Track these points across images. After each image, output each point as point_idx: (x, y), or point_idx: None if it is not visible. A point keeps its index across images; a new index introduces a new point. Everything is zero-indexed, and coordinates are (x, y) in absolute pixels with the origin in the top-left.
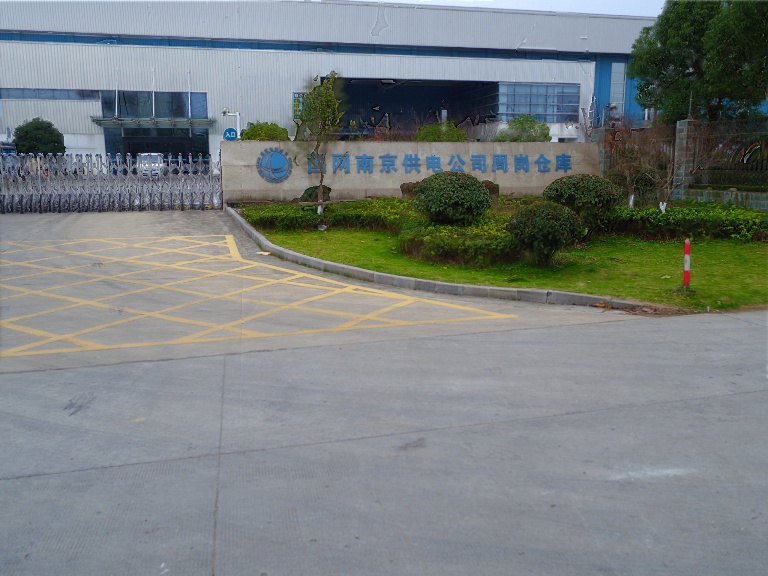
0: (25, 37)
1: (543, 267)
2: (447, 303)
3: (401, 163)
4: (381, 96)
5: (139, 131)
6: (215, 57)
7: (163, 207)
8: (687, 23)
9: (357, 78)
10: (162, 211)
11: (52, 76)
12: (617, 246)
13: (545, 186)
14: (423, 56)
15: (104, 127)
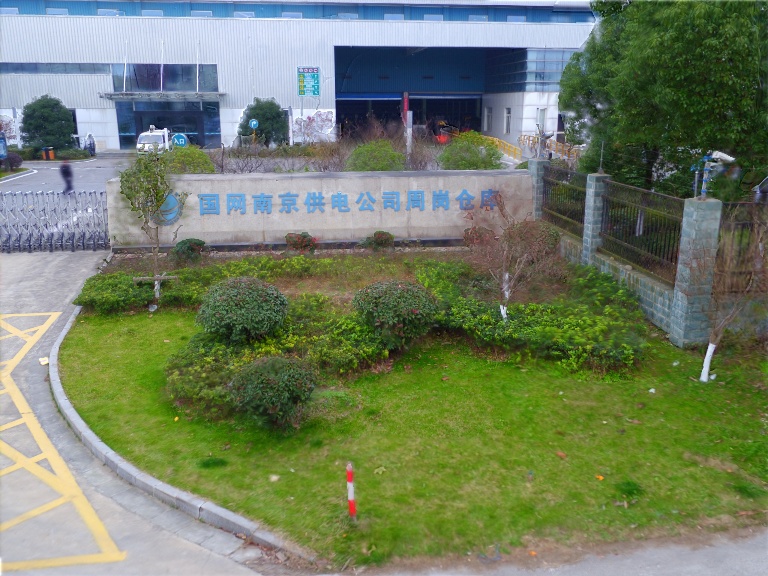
0: (50, 4)
1: (273, 430)
2: (93, 510)
3: (303, 202)
4: (410, 59)
5: (150, 105)
6: (225, 27)
7: (56, 247)
8: (609, 57)
9: (373, 46)
10: (51, 253)
11: (63, 50)
12: (421, 371)
13: (467, 225)
14: (444, 21)
15: (116, 101)
